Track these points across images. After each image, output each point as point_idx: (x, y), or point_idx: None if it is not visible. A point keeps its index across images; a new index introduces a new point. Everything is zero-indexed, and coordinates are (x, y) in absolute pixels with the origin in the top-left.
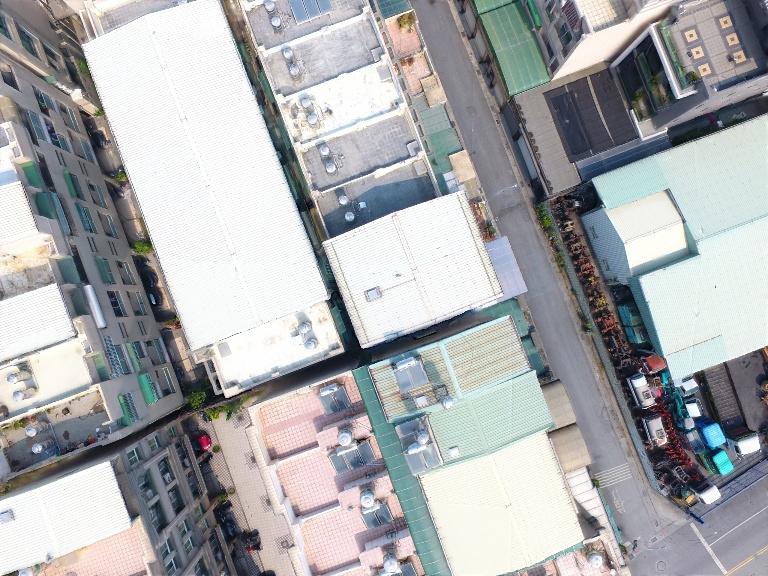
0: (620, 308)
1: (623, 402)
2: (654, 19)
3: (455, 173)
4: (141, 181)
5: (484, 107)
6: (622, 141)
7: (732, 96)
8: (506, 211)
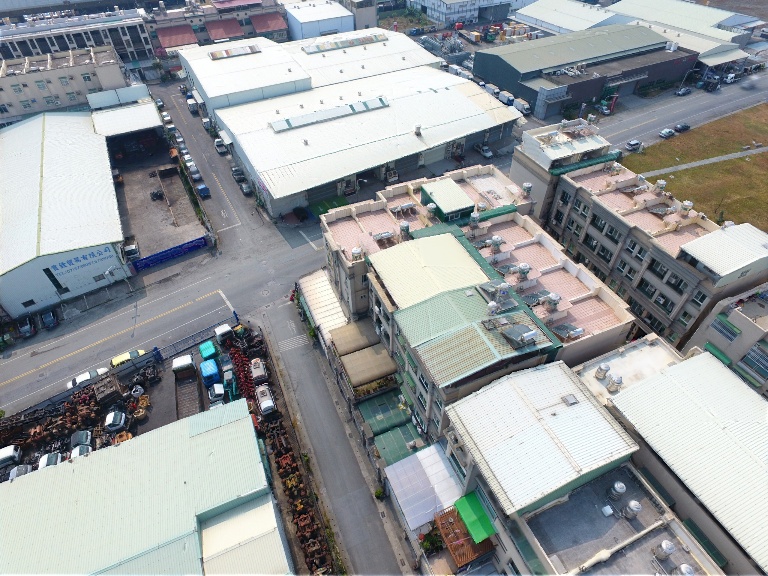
0: (271, 478)
1: None
2: None
3: None
4: None
5: None
6: None
7: None
8: None
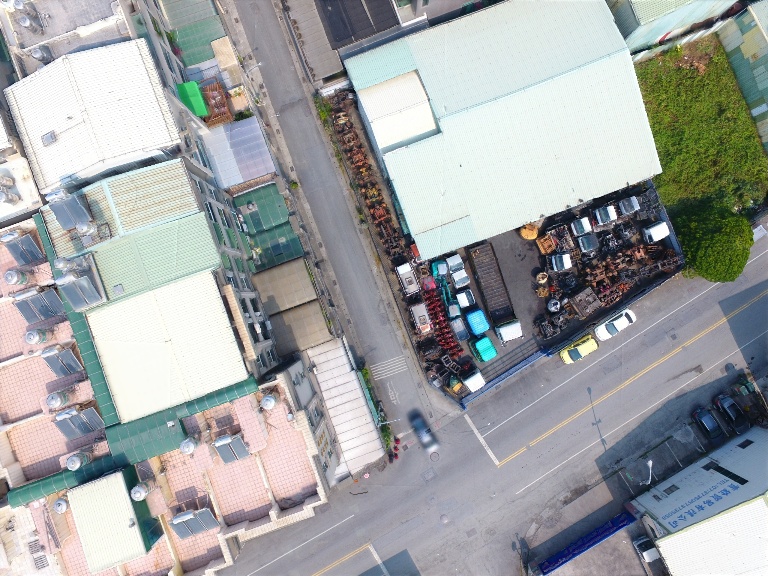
0: None
1: (393, 292)
2: None
3: (217, 59)
4: None
5: (267, 3)
6: (383, 28)
7: None
8: (287, 106)
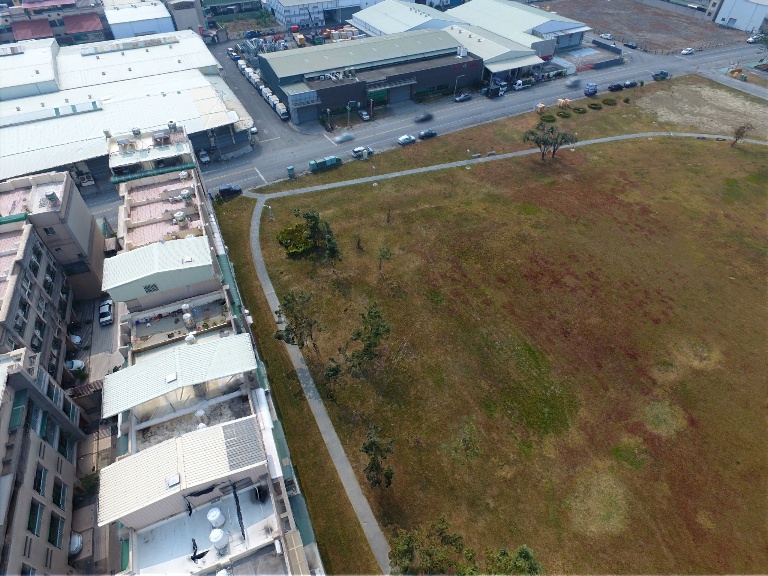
0: None
1: None
2: None
3: None
4: None
5: None
6: None
7: None
8: None
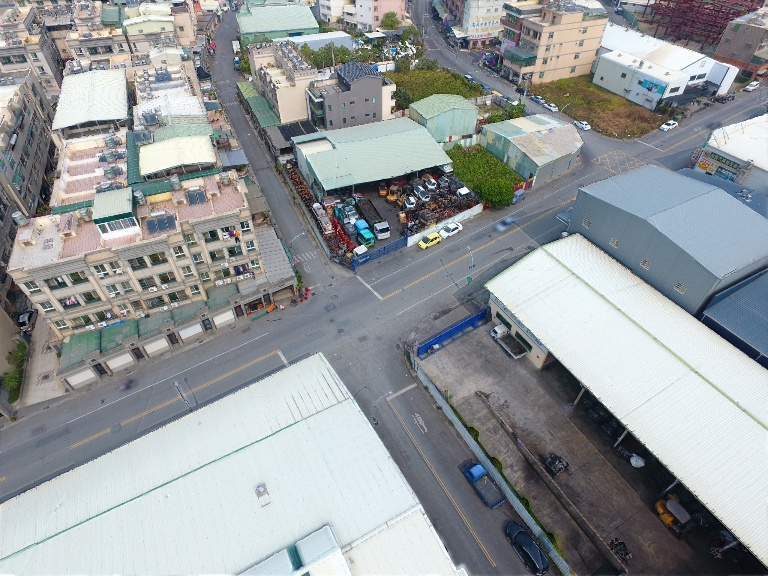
0: None
1: None
2: (307, 87)
3: None
4: (64, 97)
5: None
6: None
7: (349, 110)
8: (260, 169)
